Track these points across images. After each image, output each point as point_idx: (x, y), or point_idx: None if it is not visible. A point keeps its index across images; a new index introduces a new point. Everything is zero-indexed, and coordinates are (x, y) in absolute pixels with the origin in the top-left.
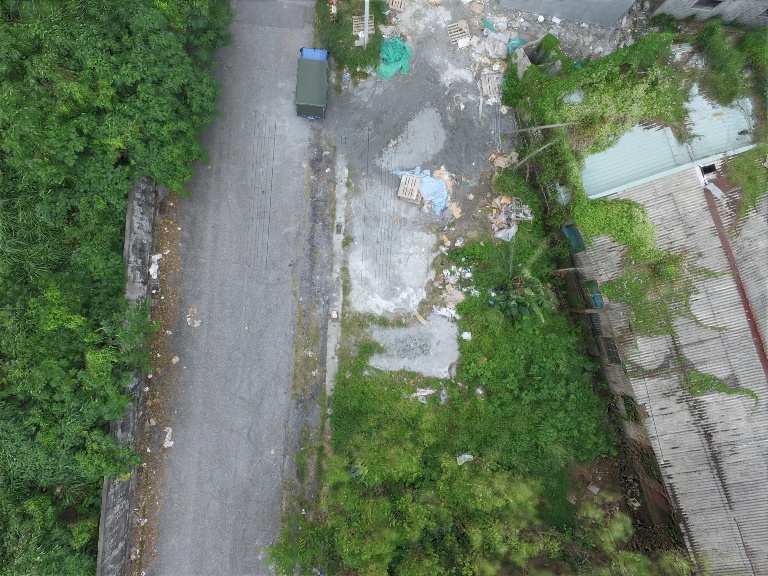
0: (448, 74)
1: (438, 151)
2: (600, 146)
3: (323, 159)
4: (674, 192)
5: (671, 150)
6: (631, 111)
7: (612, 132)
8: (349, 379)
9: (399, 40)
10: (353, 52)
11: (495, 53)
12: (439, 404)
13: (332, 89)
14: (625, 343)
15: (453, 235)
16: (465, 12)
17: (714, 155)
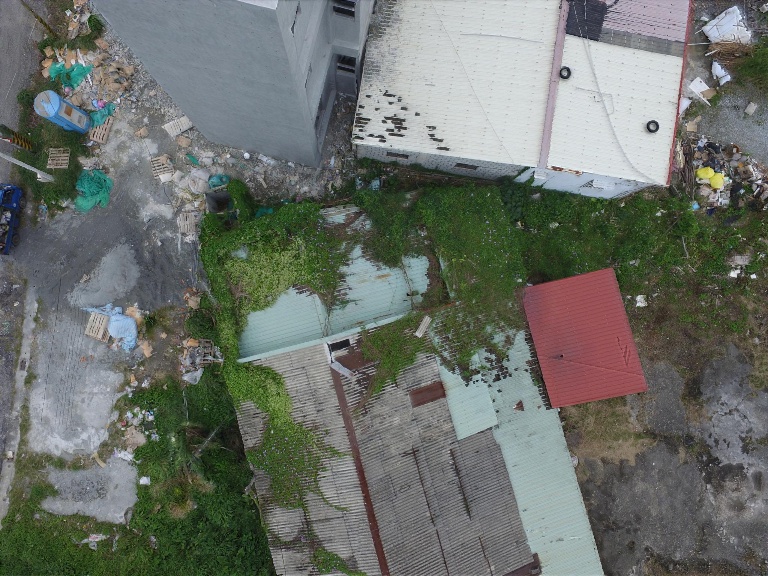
0: (148, 209)
1: (131, 288)
2: (259, 305)
3: (12, 292)
4: (306, 366)
5: (318, 317)
6: (282, 275)
7: (269, 293)
8: (16, 524)
9: (99, 173)
10: (47, 185)
11: (196, 190)
12: (109, 552)
13: (27, 221)
14: (266, 511)
15: (141, 375)
16: (172, 145)
17: (349, 330)
